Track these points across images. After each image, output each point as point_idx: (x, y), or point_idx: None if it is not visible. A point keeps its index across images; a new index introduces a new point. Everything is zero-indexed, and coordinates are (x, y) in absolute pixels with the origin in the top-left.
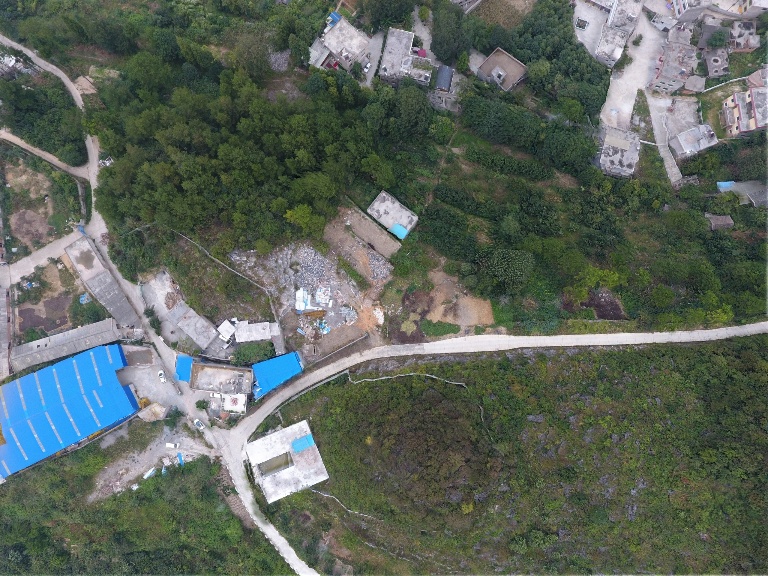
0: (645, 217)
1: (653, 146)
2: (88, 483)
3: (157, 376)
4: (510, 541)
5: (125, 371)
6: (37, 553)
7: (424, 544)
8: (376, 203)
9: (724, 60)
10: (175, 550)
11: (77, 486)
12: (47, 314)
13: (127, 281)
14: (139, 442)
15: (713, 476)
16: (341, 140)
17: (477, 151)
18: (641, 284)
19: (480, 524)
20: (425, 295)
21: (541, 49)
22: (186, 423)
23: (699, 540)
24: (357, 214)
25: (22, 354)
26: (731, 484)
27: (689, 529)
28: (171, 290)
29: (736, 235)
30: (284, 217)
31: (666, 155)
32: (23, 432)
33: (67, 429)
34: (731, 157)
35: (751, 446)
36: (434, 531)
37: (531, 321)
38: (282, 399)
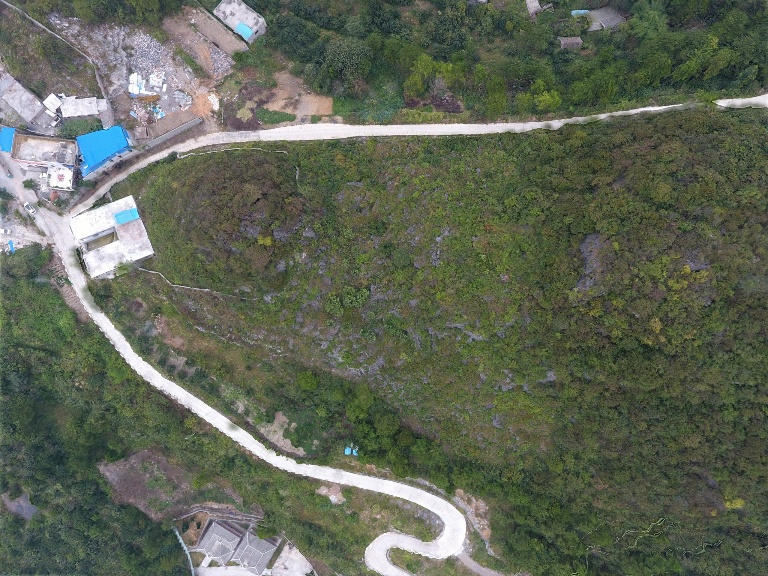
0: (500, 40)
1: None
2: None
3: None
4: (326, 302)
5: None
6: None
7: (248, 318)
8: (222, 5)
9: None
10: (10, 348)
11: None
12: None
13: None
14: None
15: (514, 219)
16: None
17: None
18: (476, 77)
19: (294, 282)
20: (266, 90)
21: None
22: (18, 209)
23: (500, 282)
24: (202, 14)
25: None
26: (529, 223)
27: (490, 271)
28: (0, 69)
29: None
30: None
31: None
32: None
33: None
34: None
35: (551, 189)
36: (254, 299)
37: (367, 111)
38: None
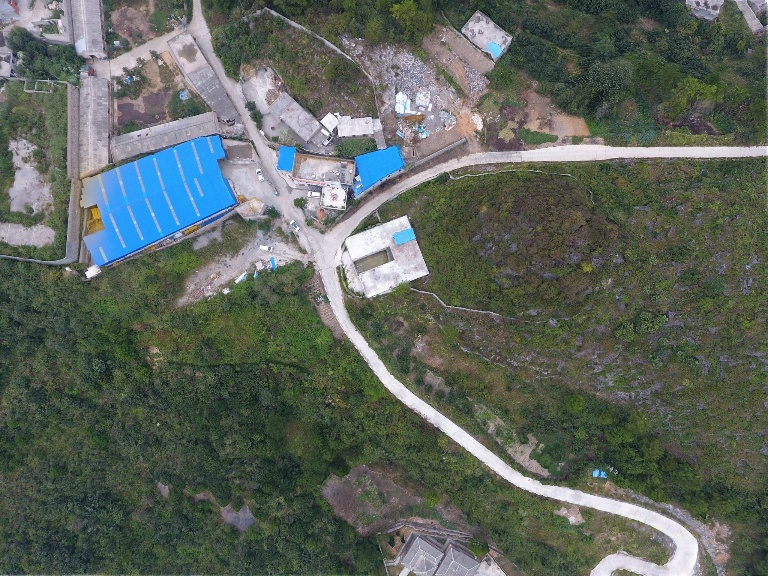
0: (729, 59)
1: (732, 1)
2: (180, 284)
3: (254, 175)
4: (617, 327)
5: (225, 164)
6: (120, 365)
7: (524, 341)
8: (470, 23)
9: None
10: (261, 364)
11: (170, 285)
12: (146, 109)
13: (227, 79)
14: (232, 245)
15: None
16: None
17: None
18: (738, 99)
19: (588, 307)
20: (520, 110)
21: None
22: (280, 227)
23: None
24: (452, 32)
25: (123, 142)
26: None
27: None
28: (272, 87)
29: None
30: (390, 11)
31: (745, 10)
32: (122, 218)
33: (166, 217)
34: None
35: None
36: (537, 322)
37: (628, 132)
38: (378, 204)
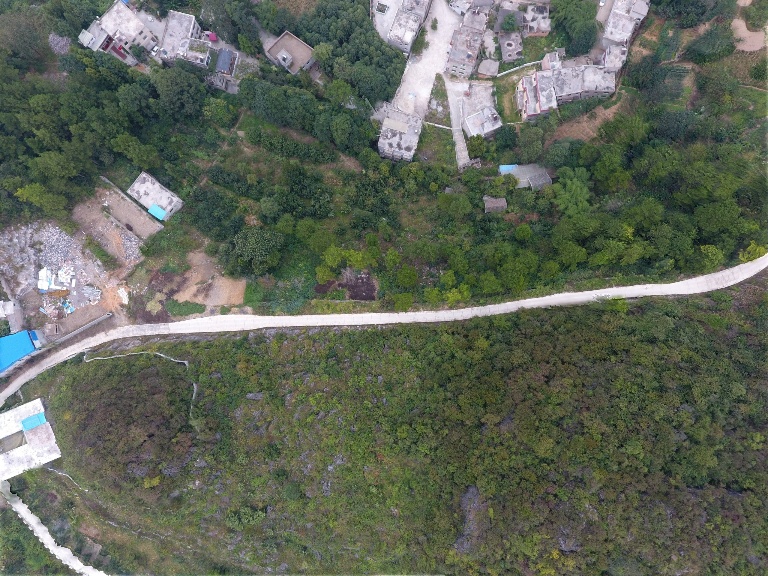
0: (425, 200)
1: (447, 130)
2: None
3: None
4: (225, 518)
5: None
6: None
7: (155, 522)
8: (136, 184)
9: (518, 44)
10: None
11: None
12: None
13: None
14: None
15: (405, 452)
16: (86, 120)
17: (261, 134)
18: (387, 264)
19: (192, 501)
20: (179, 275)
21: (331, 33)
22: None
23: (390, 515)
24: (116, 195)
25: None
26: (418, 459)
27: (380, 504)
28: None
29: (509, 217)
30: (15, 196)
31: (459, 139)
32: None
33: None
34: (515, 140)
35: (442, 422)
36: None
37: (277, 301)
38: (28, 378)
